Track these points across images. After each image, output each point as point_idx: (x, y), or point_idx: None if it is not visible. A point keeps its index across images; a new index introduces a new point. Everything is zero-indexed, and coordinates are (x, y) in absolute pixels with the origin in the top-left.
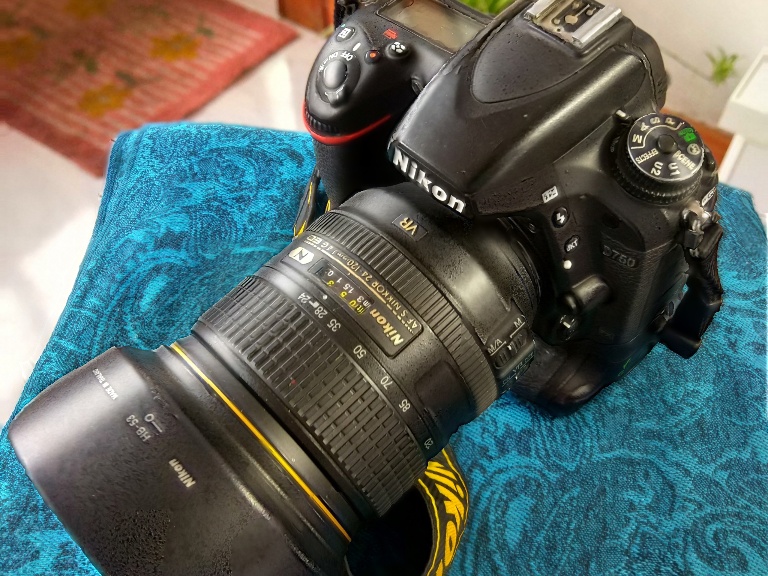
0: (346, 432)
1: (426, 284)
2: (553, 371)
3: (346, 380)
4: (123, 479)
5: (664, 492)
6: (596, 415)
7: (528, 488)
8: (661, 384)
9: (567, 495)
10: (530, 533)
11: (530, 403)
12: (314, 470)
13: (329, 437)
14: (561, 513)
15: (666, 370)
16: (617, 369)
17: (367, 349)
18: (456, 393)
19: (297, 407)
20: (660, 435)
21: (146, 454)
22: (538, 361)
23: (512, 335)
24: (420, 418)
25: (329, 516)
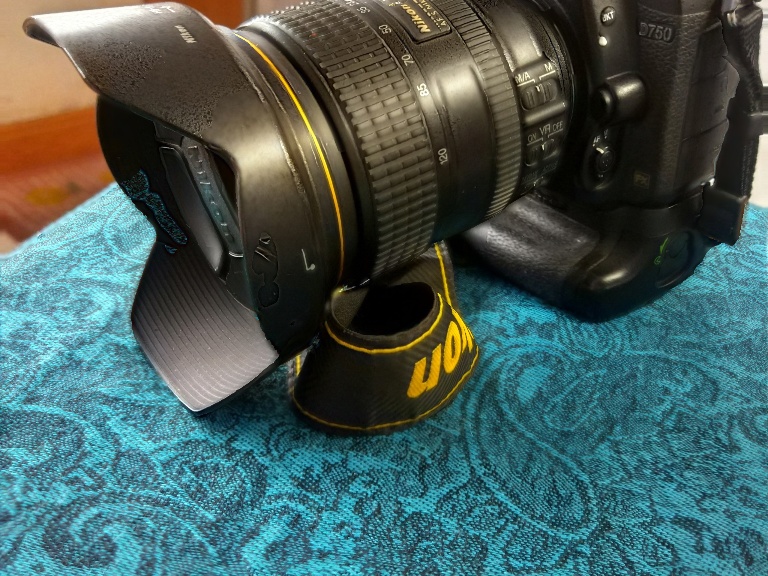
0: (358, 86)
1: (459, 2)
2: (583, 254)
3: (367, 44)
4: (125, 24)
5: (705, 386)
6: (629, 326)
7: (547, 362)
8: (703, 313)
9: (592, 373)
10: (546, 394)
11: (556, 309)
12: (318, 114)
13: (340, 84)
14: (583, 385)
15: (709, 305)
16: (653, 251)
17: (393, 29)
18: (478, 109)
19: (313, 50)
20: (701, 346)
21: (154, 19)
22: (568, 249)
23: (541, 77)
24: (437, 113)
25: (325, 170)
